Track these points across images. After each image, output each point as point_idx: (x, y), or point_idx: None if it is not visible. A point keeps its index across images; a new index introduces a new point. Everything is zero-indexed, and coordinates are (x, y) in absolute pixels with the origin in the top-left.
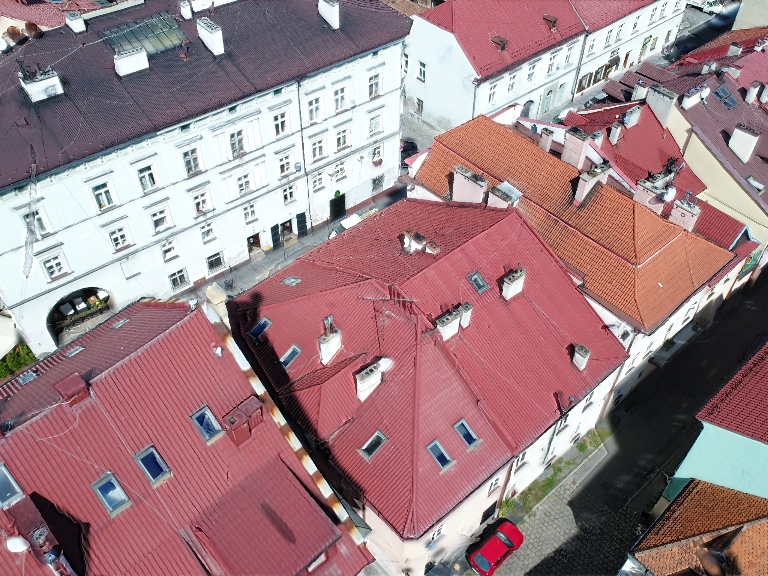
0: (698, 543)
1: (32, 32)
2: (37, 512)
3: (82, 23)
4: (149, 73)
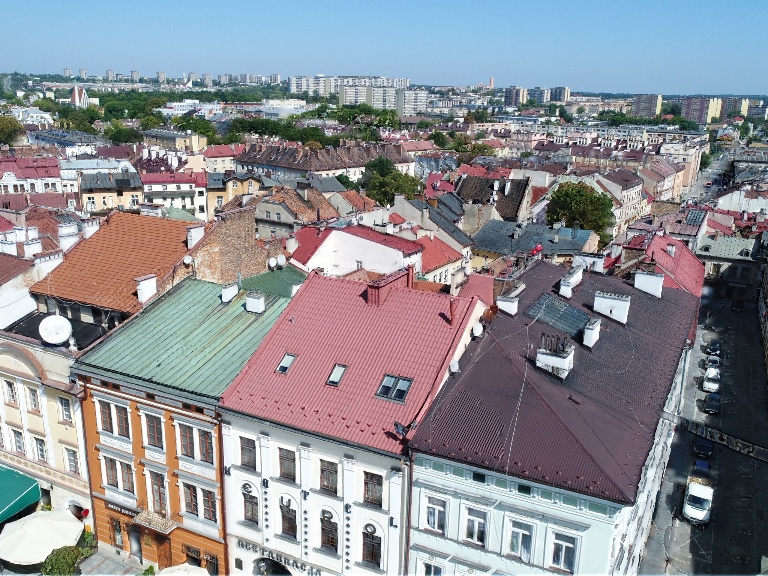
0: None
1: (493, 315)
2: None
3: (516, 305)
4: (600, 344)
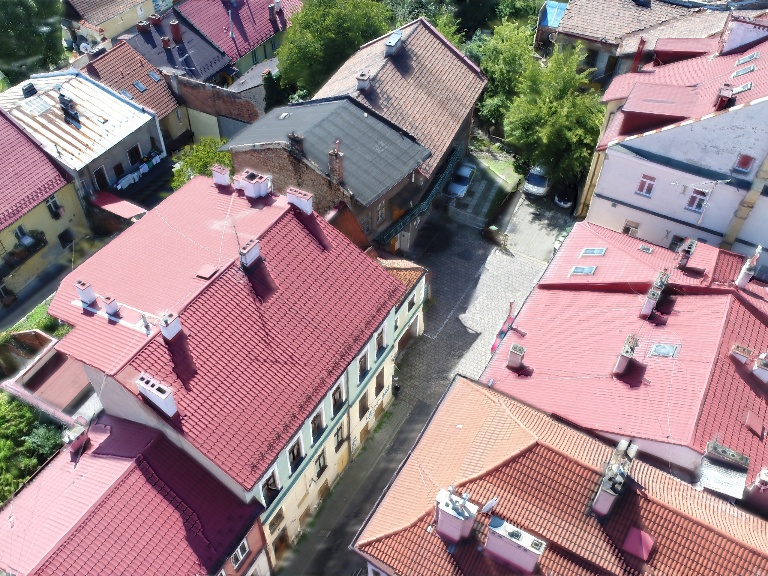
0: (384, 266)
1: None
2: (764, 24)
3: None
4: None
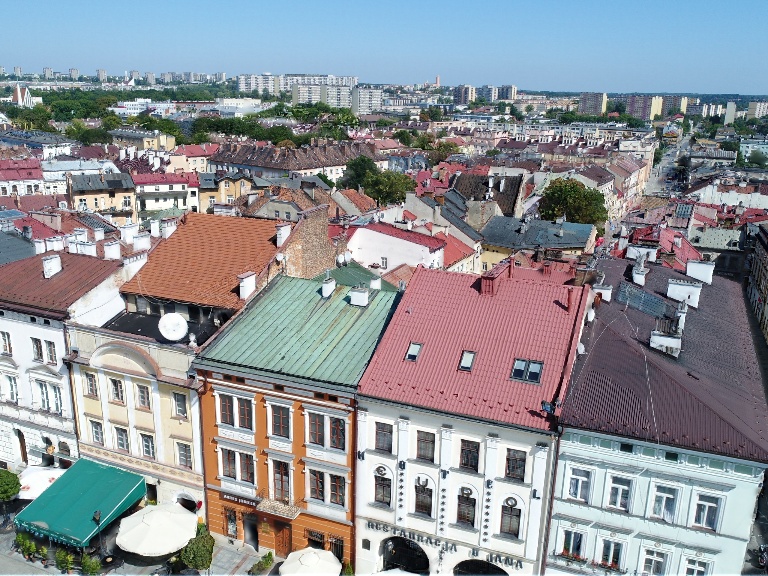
0: None
1: None
2: None
3: (610, 293)
4: (686, 326)
